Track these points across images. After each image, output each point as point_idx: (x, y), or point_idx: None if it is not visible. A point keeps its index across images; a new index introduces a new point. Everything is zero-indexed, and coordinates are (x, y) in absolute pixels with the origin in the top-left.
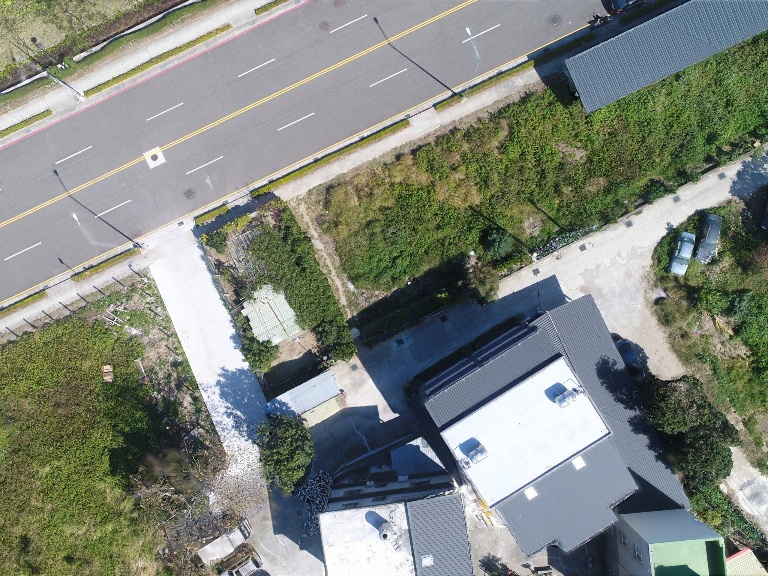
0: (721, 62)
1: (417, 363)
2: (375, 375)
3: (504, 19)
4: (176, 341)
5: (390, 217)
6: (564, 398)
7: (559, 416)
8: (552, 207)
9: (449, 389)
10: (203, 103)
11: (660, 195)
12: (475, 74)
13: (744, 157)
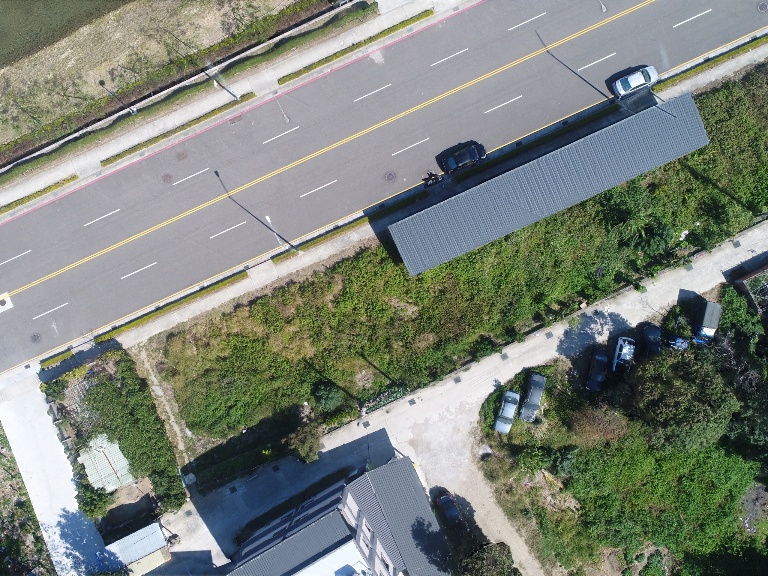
0: (550, 223)
1: (250, 510)
2: (209, 521)
3: (341, 175)
4: (20, 481)
5: (225, 368)
6: None
7: None
8: (383, 361)
9: (245, 566)
10: (50, 251)
11: (486, 354)
12: (312, 228)
13: (571, 317)
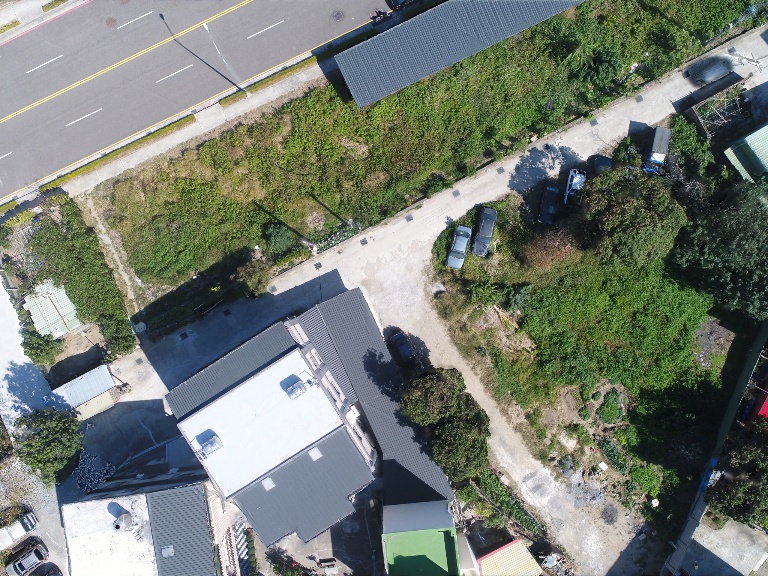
0: (499, 57)
1: (201, 357)
2: (160, 369)
3: (288, 15)
4: None
5: (173, 212)
6: (292, 389)
7: (294, 407)
8: (333, 201)
9: (188, 381)
10: None
11: (438, 189)
12: (260, 70)
13: None
